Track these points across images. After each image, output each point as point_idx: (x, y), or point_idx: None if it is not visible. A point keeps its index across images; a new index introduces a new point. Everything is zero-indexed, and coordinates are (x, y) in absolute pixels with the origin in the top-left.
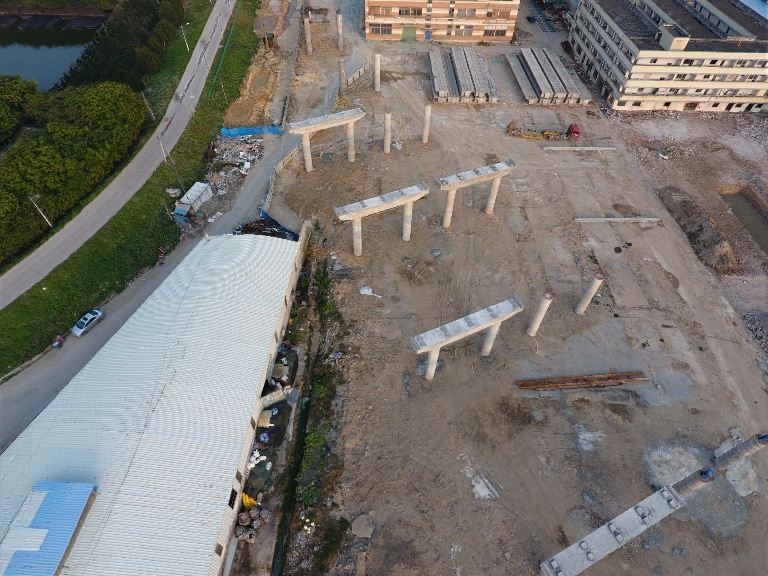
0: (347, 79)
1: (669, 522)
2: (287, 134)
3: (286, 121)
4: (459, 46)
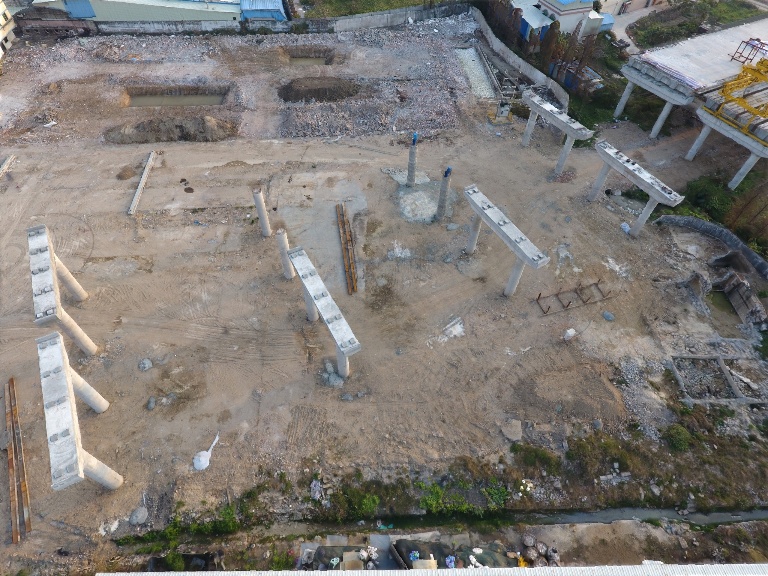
0: None
1: (455, 219)
2: None
3: None
4: None
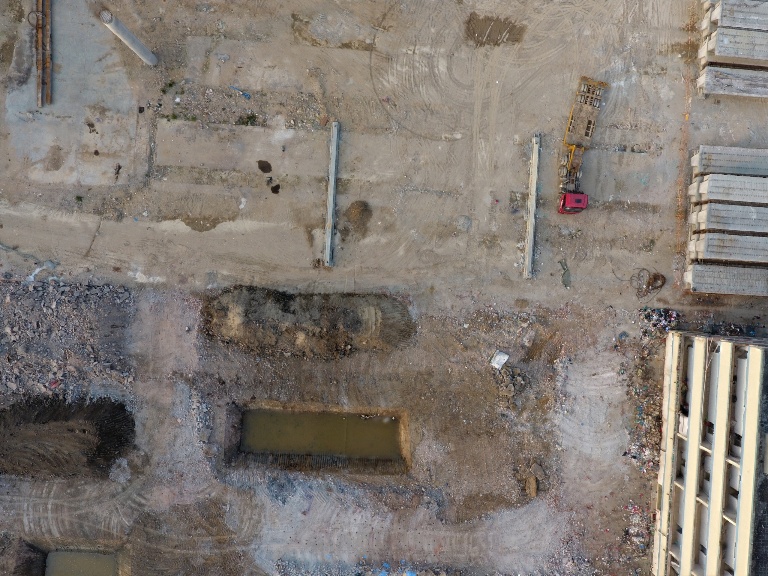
0: None
1: None
2: None
3: None
4: None
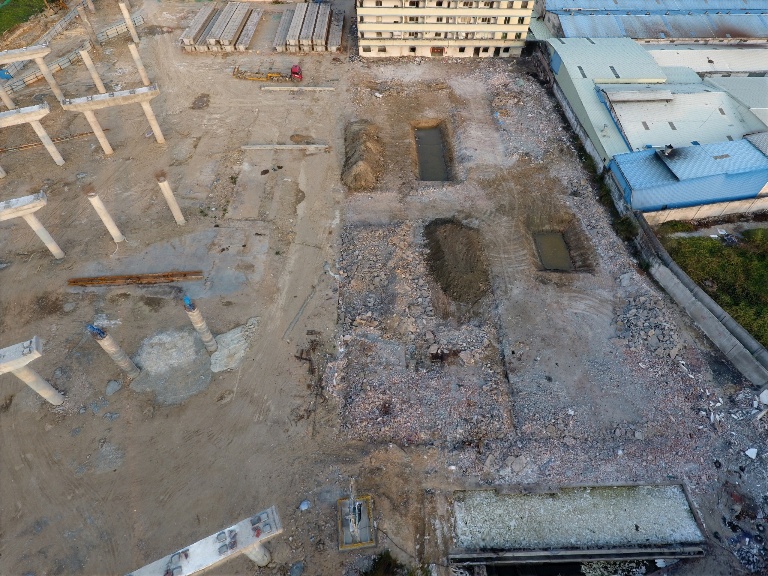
0: (106, 31)
1: (123, 392)
2: (15, 78)
3: (23, 68)
4: (251, 4)
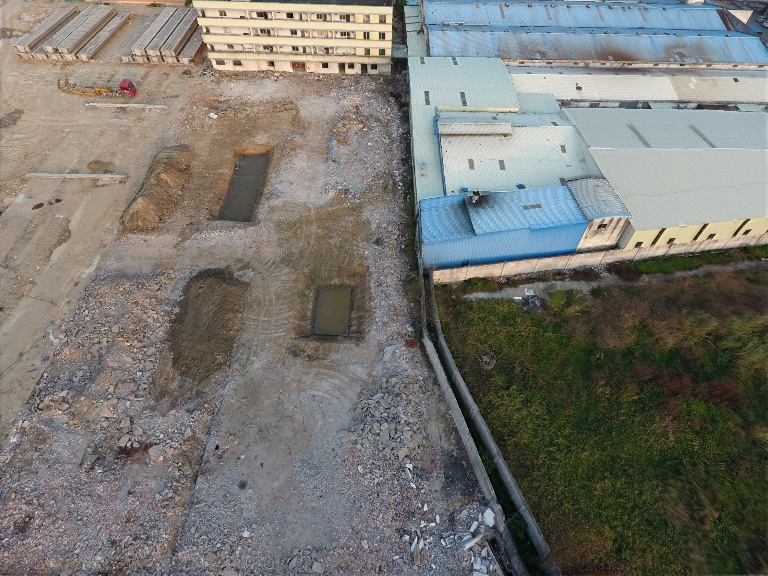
0: None
1: None
2: None
3: None
4: (124, 7)
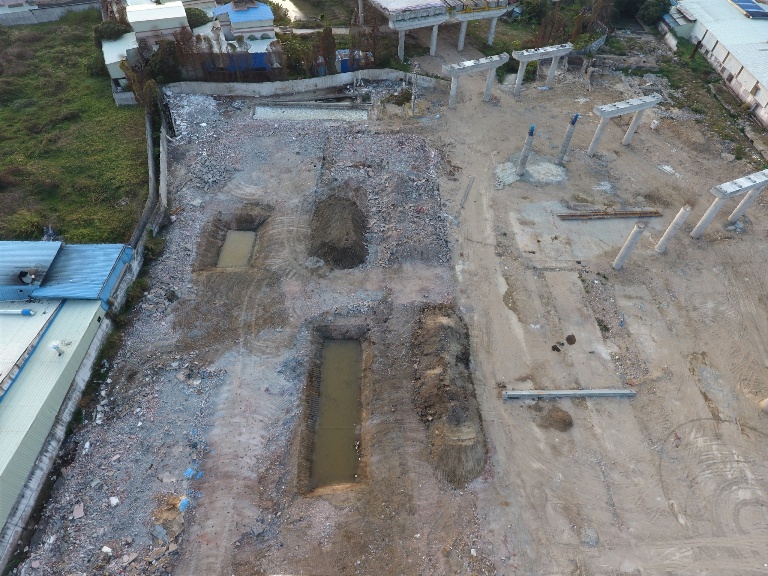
0: None
1: None
2: None
3: None
4: None
